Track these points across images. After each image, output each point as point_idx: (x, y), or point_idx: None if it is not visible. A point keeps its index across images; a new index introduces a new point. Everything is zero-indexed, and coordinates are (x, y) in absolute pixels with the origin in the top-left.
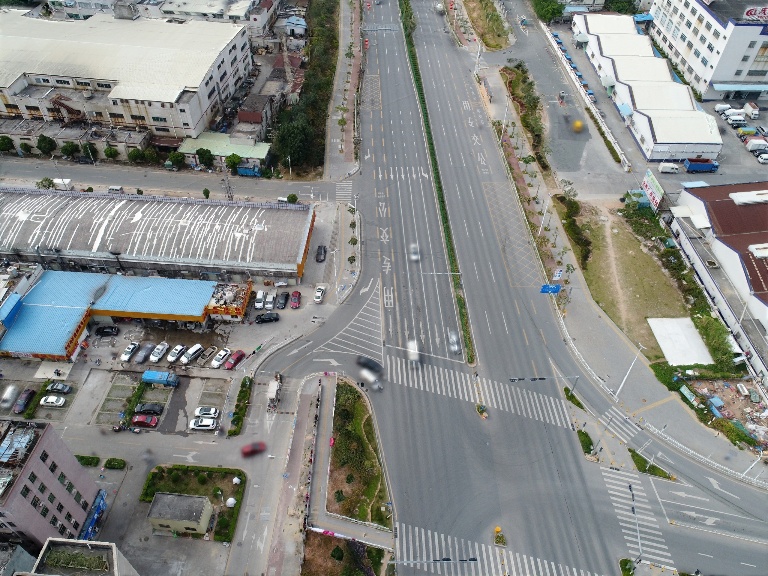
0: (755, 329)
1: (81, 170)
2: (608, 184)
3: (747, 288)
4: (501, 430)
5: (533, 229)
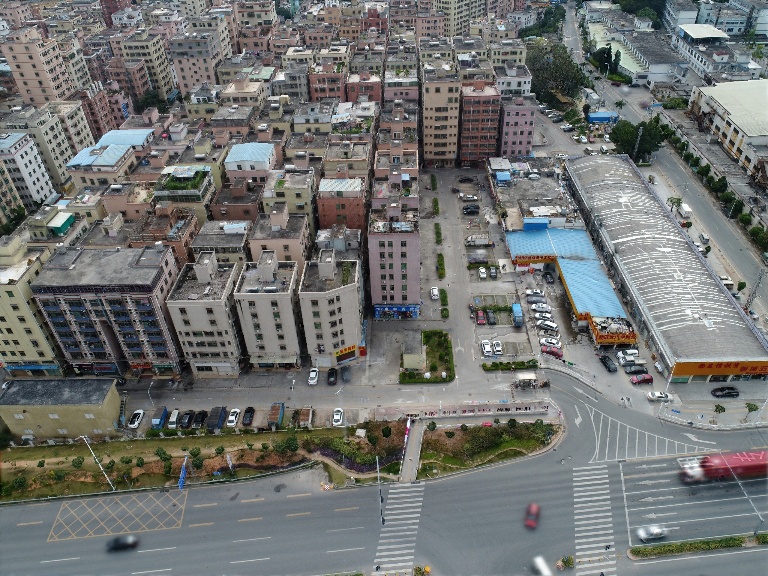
0: None
1: (715, 215)
2: None
3: None
4: None
5: None
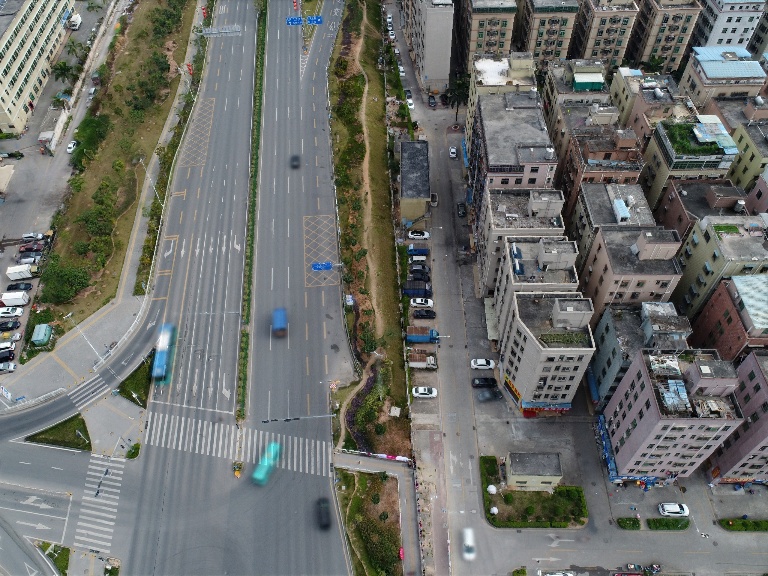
0: None
1: None
2: None
3: None
4: None
5: None
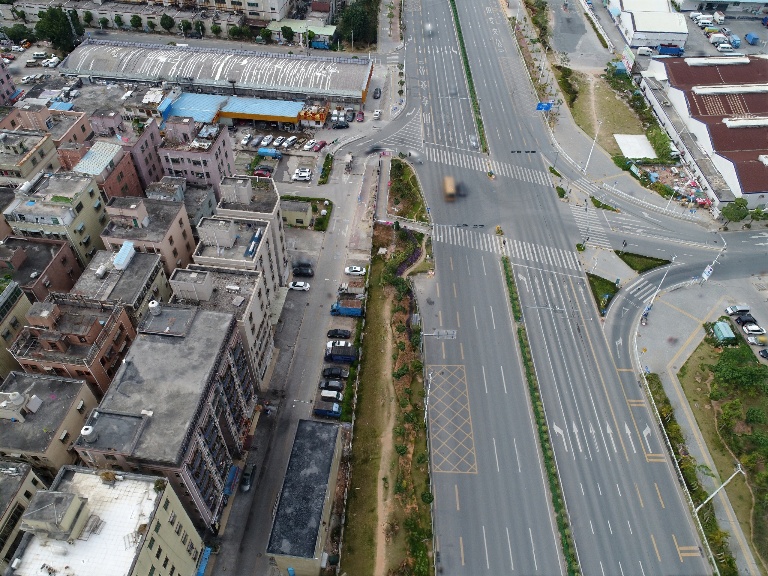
0: (689, 138)
1: (193, 42)
2: (596, 61)
3: (687, 113)
4: (504, 185)
5: (535, 81)
